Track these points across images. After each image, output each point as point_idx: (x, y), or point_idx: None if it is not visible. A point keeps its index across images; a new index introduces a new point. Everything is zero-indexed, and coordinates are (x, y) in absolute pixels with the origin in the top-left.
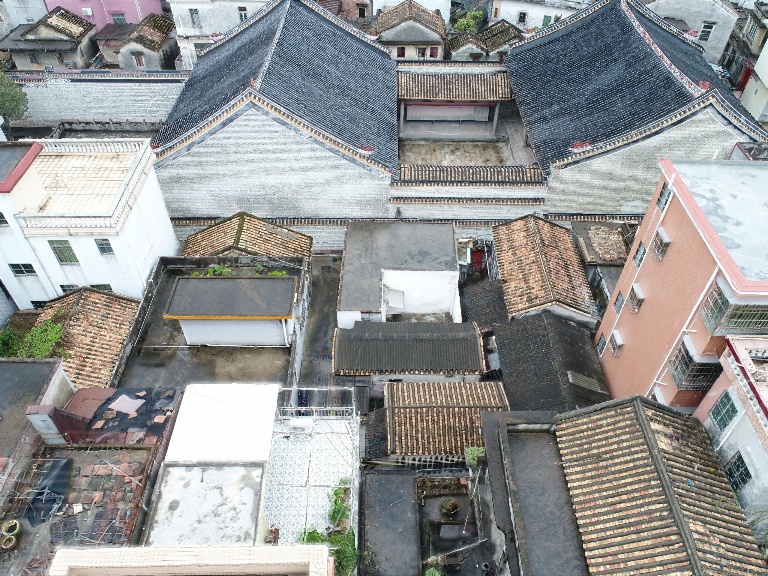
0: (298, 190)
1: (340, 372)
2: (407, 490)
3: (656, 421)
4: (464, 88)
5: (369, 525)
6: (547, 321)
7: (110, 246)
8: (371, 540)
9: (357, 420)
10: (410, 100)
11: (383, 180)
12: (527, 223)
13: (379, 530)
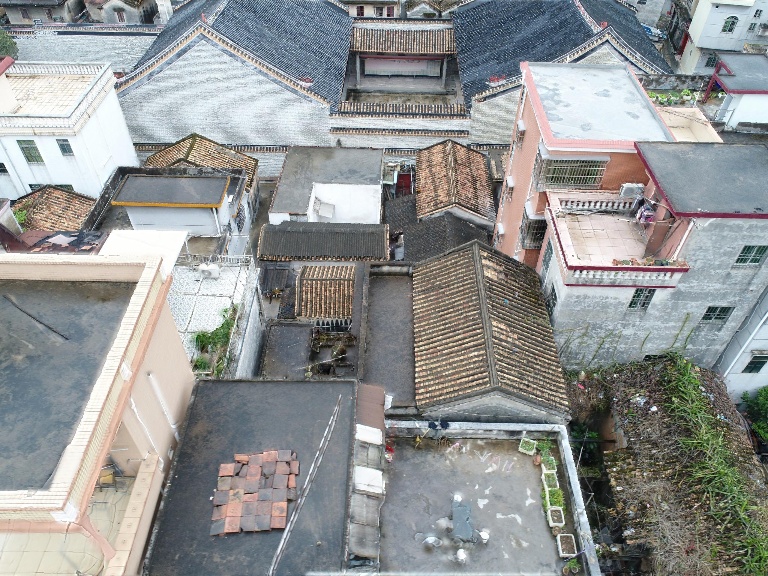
0: (248, 120)
1: (264, 257)
2: (303, 337)
3: (490, 261)
4: (414, 42)
5: (267, 360)
6: (447, 220)
7: (70, 147)
8: (267, 370)
9: (257, 270)
10: (365, 53)
11: (323, 111)
12: (445, 146)
13: (275, 364)
